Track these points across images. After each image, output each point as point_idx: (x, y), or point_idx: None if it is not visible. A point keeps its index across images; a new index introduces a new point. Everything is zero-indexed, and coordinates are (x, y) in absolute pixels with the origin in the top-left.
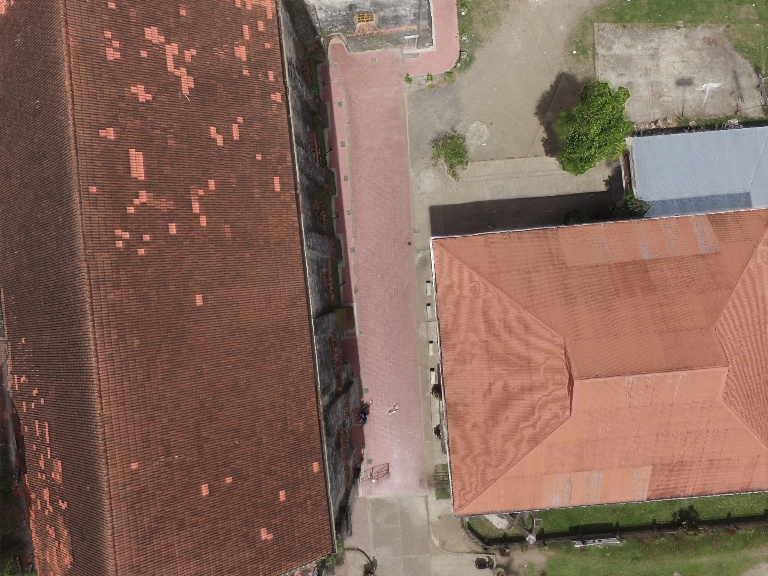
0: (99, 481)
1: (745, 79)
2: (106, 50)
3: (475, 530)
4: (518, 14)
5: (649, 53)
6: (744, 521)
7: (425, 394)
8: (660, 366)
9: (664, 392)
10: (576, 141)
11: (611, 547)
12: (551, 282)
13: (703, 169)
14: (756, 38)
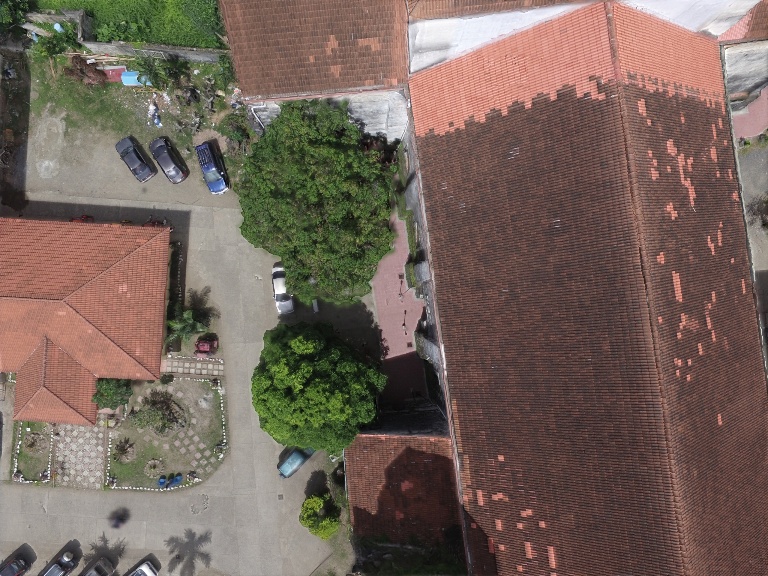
0: None
1: None
2: (651, 170)
3: None
4: None
5: None
6: None
7: None
8: None
9: None
10: None
11: None
12: None
13: None
14: None
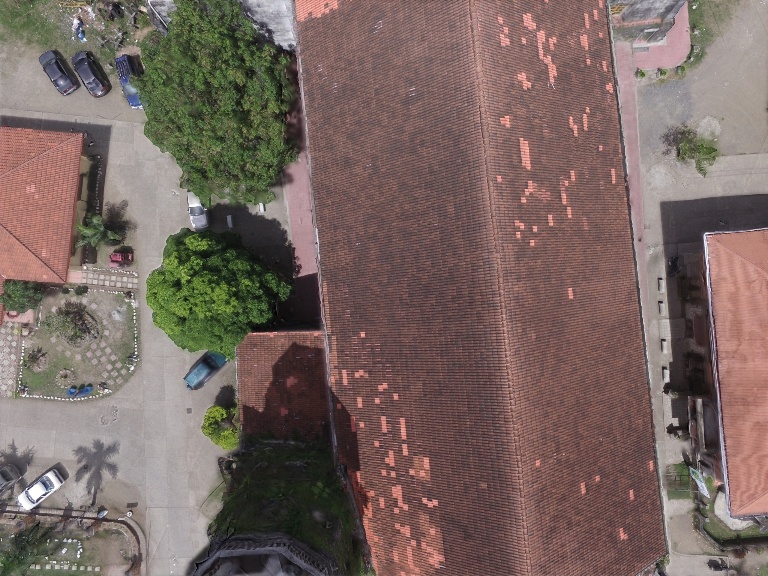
0: (507, 479)
1: None
2: (500, 36)
3: (708, 531)
4: (749, 8)
5: None
6: None
7: (656, 393)
8: None
9: None
10: None
11: None
12: None
13: None
14: None
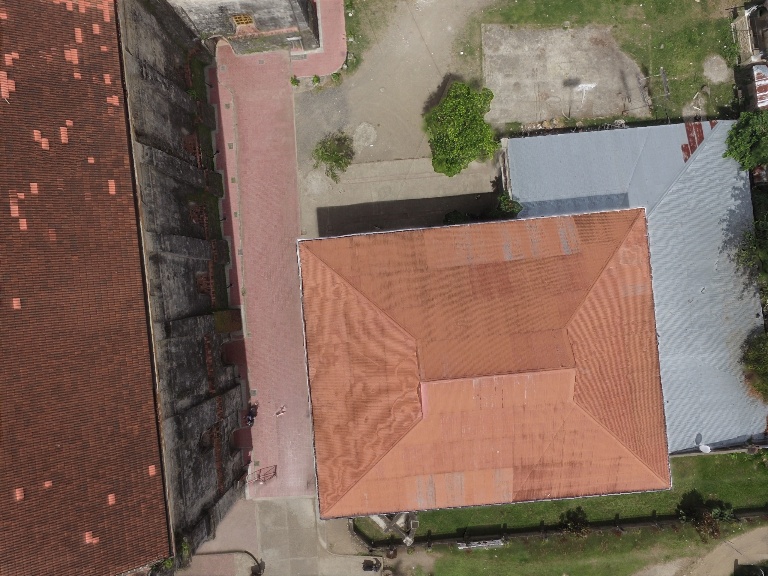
0: None
1: (632, 79)
2: None
3: (362, 532)
4: (405, 15)
5: (536, 54)
6: (631, 522)
7: None
8: (507, 368)
9: (514, 394)
10: (440, 142)
11: (499, 549)
12: (410, 284)
13: (582, 170)
14: (643, 38)
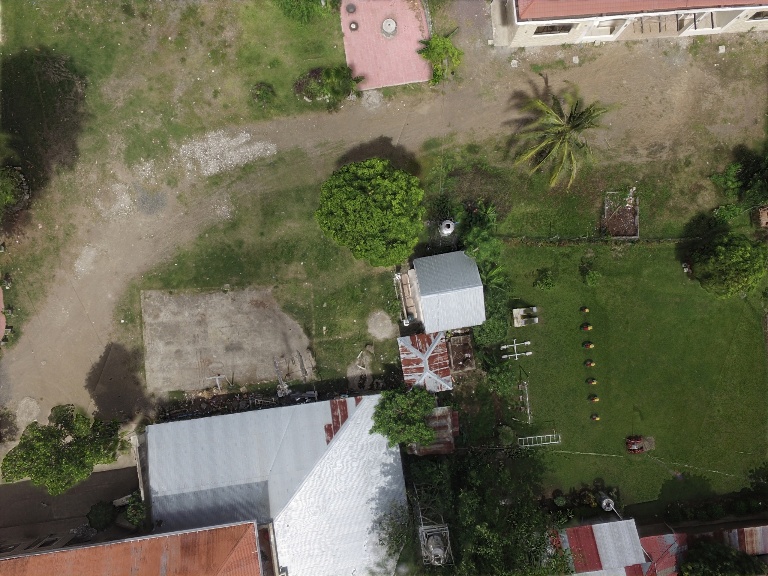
0: None
1: (295, 341)
2: None
3: None
4: (64, 284)
5: (196, 319)
6: None
7: None
8: None
9: None
10: None
11: None
12: None
13: (223, 457)
14: (305, 297)
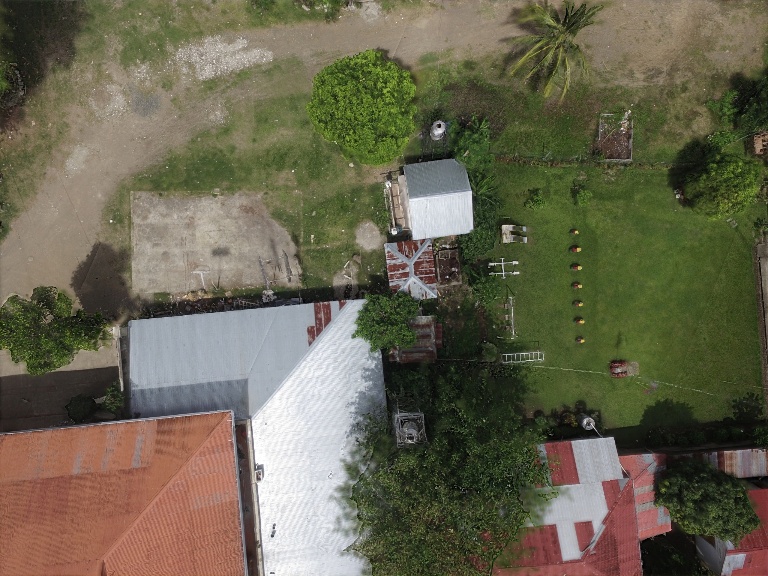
0: None
1: (282, 248)
2: None
3: None
4: (55, 182)
5: (185, 222)
6: None
7: None
8: None
9: None
10: None
11: None
12: None
13: (205, 354)
14: (294, 205)
